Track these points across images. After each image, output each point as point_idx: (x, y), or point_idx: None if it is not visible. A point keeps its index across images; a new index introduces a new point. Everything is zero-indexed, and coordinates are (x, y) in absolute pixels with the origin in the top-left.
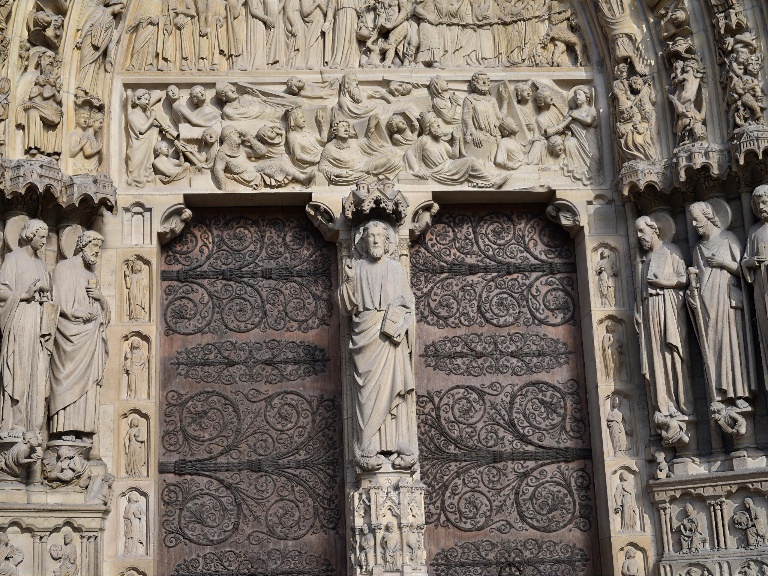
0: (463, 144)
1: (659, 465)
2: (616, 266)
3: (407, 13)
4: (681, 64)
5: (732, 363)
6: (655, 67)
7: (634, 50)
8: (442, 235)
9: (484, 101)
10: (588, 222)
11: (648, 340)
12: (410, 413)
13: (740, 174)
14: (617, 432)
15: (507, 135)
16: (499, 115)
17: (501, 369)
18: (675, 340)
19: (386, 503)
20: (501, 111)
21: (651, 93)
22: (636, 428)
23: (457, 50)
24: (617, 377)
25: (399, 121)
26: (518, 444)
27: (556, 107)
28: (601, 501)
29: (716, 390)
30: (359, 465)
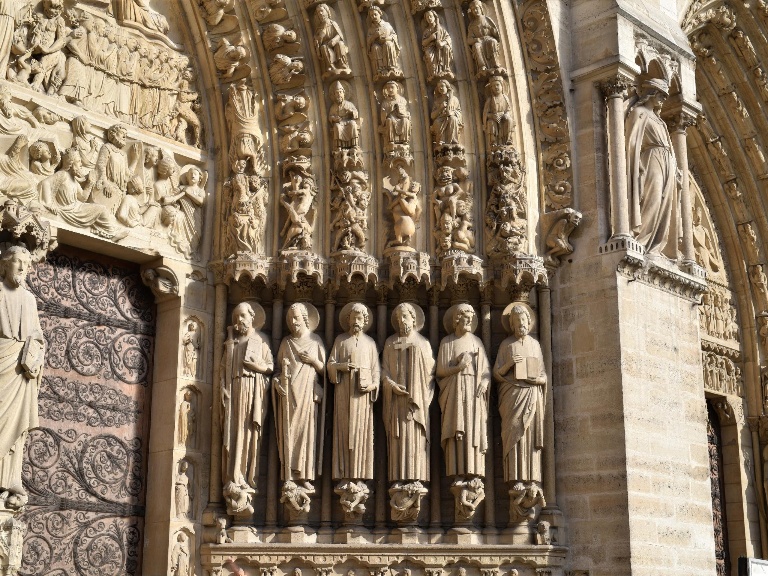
0: (93, 189)
1: (222, 531)
2: (200, 340)
3: (64, 43)
4: (301, 179)
5: (307, 449)
6: (271, 172)
7: (255, 151)
8: (44, 271)
9: (120, 154)
10: (184, 294)
11: (233, 415)
12: (22, 451)
13: (338, 288)
14: (183, 495)
15: (132, 193)
16: (128, 171)
17: (78, 417)
18: (260, 420)
19: None
20: (130, 168)
21: (266, 195)
22: (198, 493)
23: (99, 96)
24: (189, 443)
25: (46, 150)
26: (83, 494)
27: (170, 178)
28: (154, 558)
29: (291, 471)
30: None
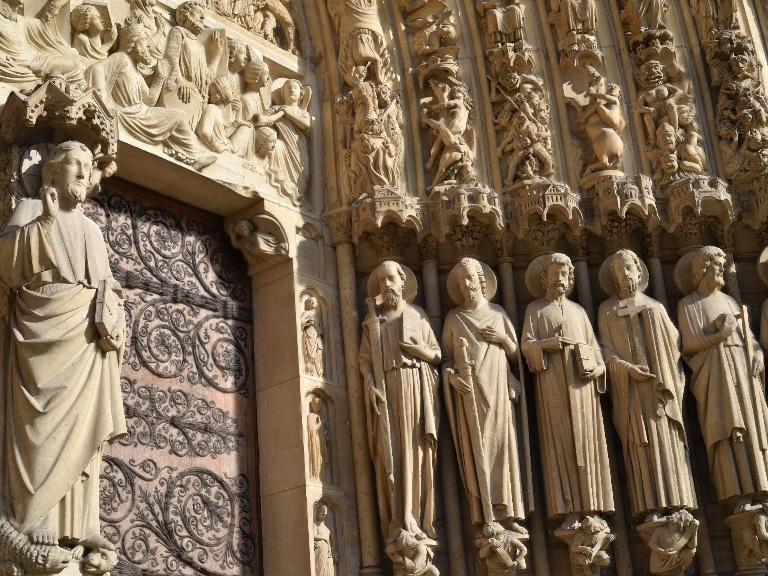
0: None
1: None
2: (322, 324)
3: None
4: None
5: (511, 472)
6: (401, 84)
7: None
8: (92, 216)
9: (197, 42)
10: (296, 255)
11: (393, 427)
12: (98, 478)
13: (521, 236)
14: (326, 556)
15: (216, 101)
16: (207, 71)
17: (157, 441)
18: (435, 431)
19: None
20: (210, 67)
21: (400, 112)
22: (345, 554)
23: None
24: (324, 477)
25: (97, 15)
26: (173, 563)
27: (259, 93)
28: None
29: (491, 506)
30: (21, 559)
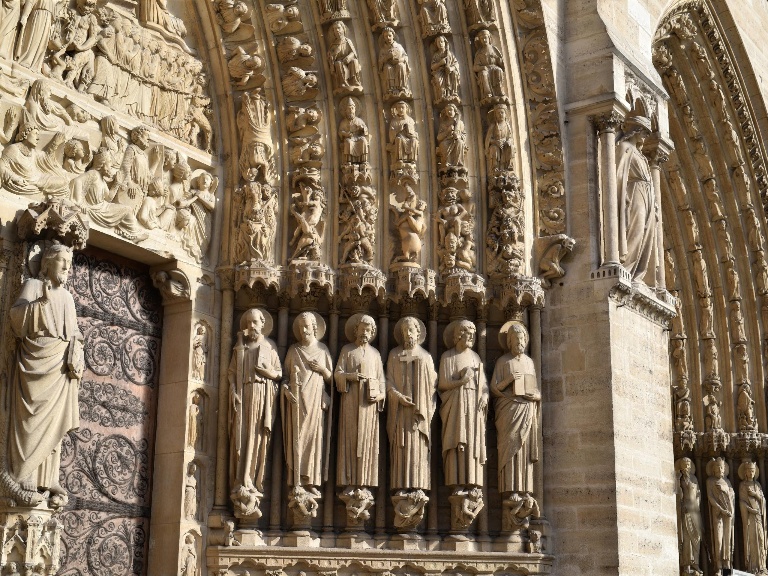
0: None
1: (230, 533)
2: (207, 344)
3: (96, 42)
4: (312, 191)
5: (315, 455)
6: (280, 182)
7: (266, 160)
8: None
9: (144, 156)
10: (195, 297)
11: (244, 420)
12: (60, 450)
13: None
14: (192, 497)
15: (152, 195)
16: (149, 173)
17: (93, 417)
18: None
19: (41, 542)
20: (151, 170)
21: (276, 204)
22: (205, 496)
23: (125, 96)
24: (197, 446)
25: (81, 148)
26: (96, 494)
27: (183, 182)
28: (162, 559)
29: (300, 476)
30: (16, 498)
